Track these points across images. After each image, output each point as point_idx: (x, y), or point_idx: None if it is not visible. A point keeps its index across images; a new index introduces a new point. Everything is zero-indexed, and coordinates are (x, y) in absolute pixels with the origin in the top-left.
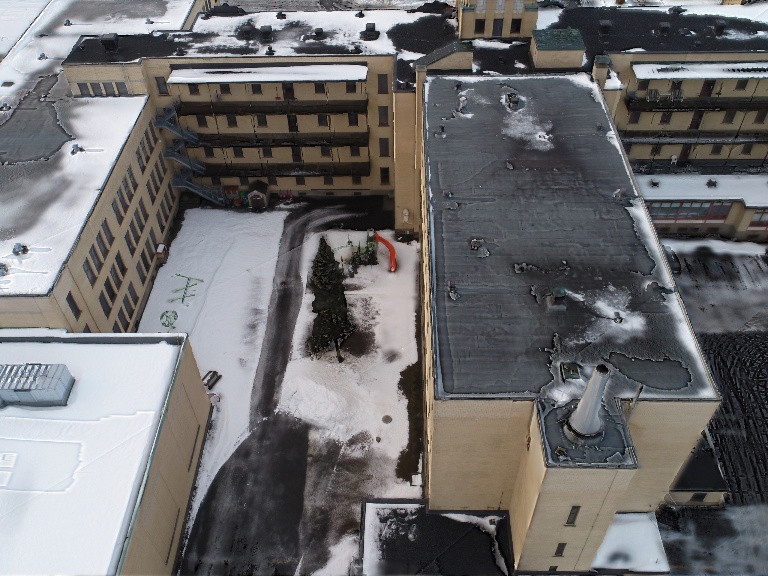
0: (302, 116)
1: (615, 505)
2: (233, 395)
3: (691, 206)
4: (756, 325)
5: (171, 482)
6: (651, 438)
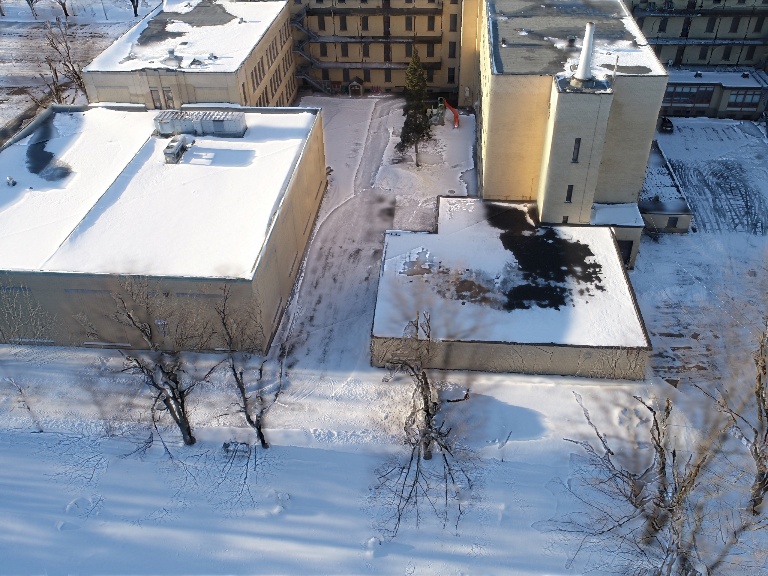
0: (394, 22)
1: (602, 137)
2: (342, 179)
3: (682, 91)
4: (728, 157)
5: None
6: (628, 116)
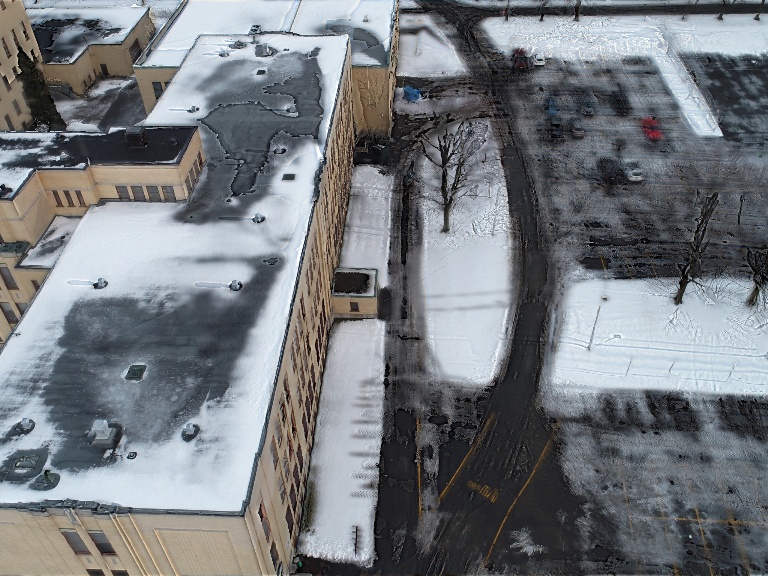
0: None
1: None
2: None
3: None
4: None
5: None
6: None
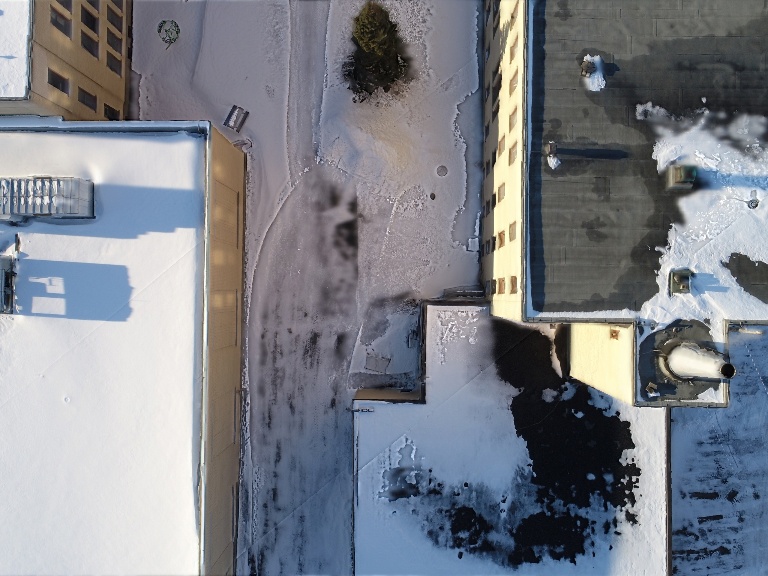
0: None
1: None
2: (266, 139)
3: None
4: None
5: (226, 280)
6: None
